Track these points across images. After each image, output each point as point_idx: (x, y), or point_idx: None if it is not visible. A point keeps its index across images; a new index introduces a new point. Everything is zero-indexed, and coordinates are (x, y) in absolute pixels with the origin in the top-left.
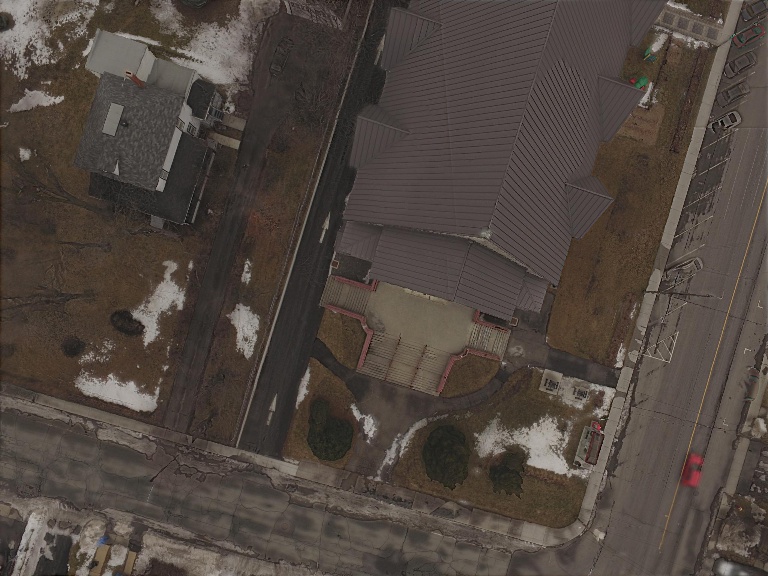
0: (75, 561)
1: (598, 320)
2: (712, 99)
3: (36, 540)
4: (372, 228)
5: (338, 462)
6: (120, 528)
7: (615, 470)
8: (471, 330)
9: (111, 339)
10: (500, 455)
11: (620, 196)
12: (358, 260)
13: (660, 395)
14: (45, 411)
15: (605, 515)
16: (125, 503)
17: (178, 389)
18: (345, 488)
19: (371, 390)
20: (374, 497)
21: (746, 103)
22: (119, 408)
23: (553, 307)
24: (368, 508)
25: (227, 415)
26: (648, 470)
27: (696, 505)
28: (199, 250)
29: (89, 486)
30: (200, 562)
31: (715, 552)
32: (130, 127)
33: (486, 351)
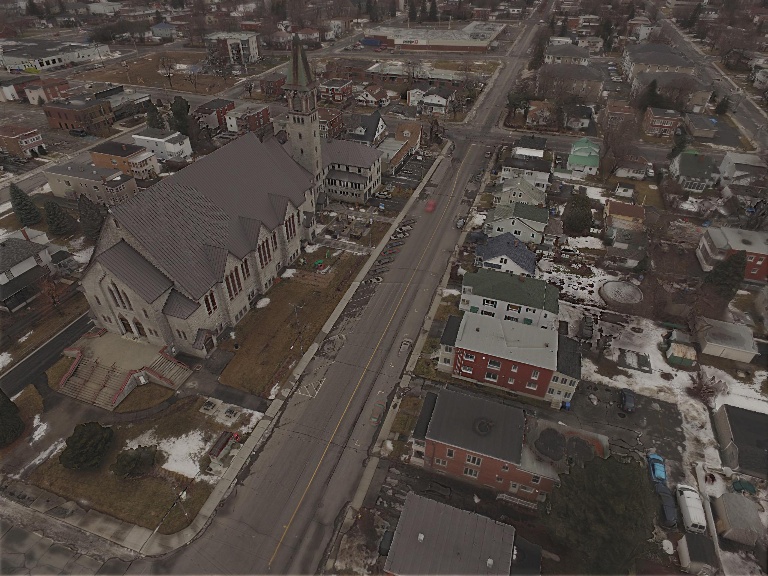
0: None
1: (263, 368)
2: (366, 272)
3: None
4: None
5: None
6: None
7: (245, 479)
8: (156, 359)
9: None
10: None
11: (298, 308)
12: None
13: (302, 420)
14: None
15: (221, 523)
16: None
17: None
18: None
19: (60, 405)
20: (1, 494)
21: (386, 274)
22: None
23: (232, 360)
24: None
25: None
26: (276, 480)
27: (319, 518)
28: (4, 325)
29: None
30: None
31: (333, 573)
32: (5, 247)
33: None
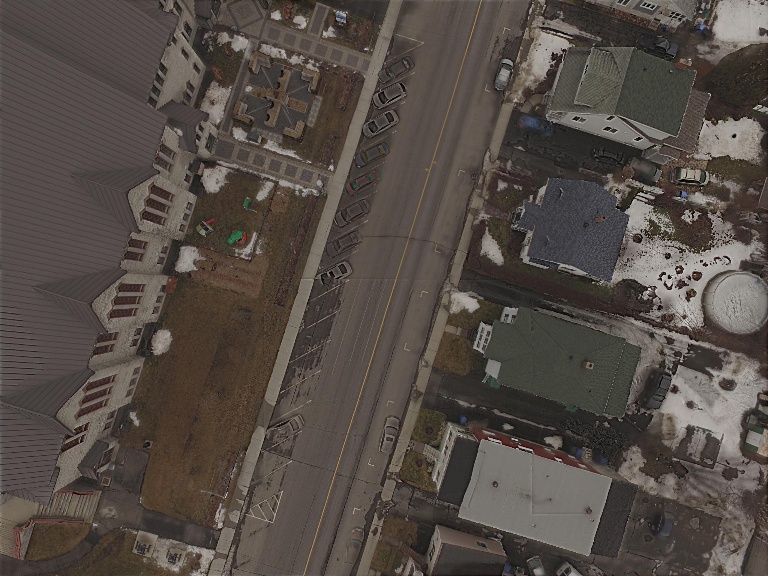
0: None
1: (195, 480)
2: (321, 249)
3: None
4: None
5: None
6: None
7: None
8: None
9: None
10: None
11: (220, 351)
12: None
13: (262, 557)
14: None
15: None
16: None
17: None
18: None
19: None
20: None
21: (358, 253)
22: None
23: (148, 466)
24: None
25: None
26: None
27: None
28: None
29: None
30: None
31: None
32: None
33: (66, 516)
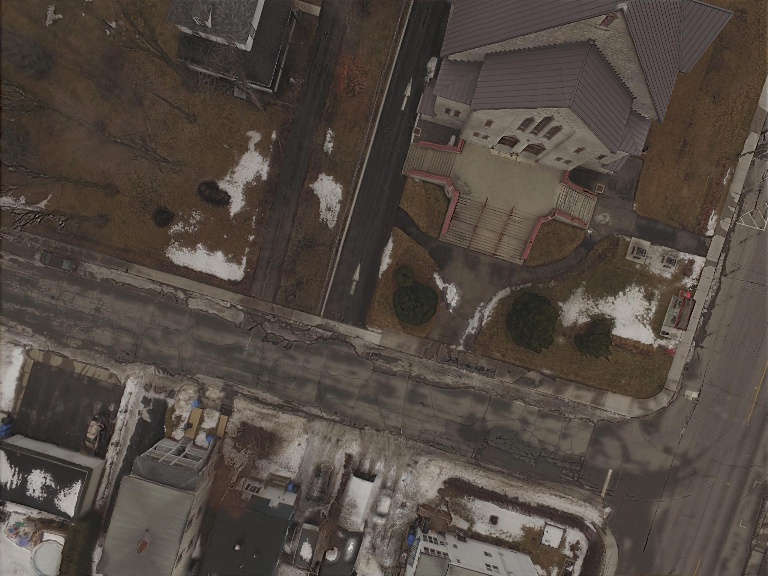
0: (171, 423)
1: (689, 186)
2: None
3: (134, 403)
4: (470, 65)
5: (421, 331)
6: (212, 393)
7: (703, 341)
8: (559, 192)
9: (199, 209)
10: (585, 324)
11: (715, 55)
12: (441, 127)
13: (753, 264)
14: (138, 281)
15: (692, 386)
16: (216, 369)
17: (264, 259)
18: (428, 357)
19: (454, 259)
20: (457, 366)
21: None
22: (208, 277)
23: (642, 173)
24: (451, 377)
25: (312, 284)
26: (738, 341)
27: None
28: (282, 120)
29: (182, 353)
30: (288, 426)
31: None
32: None
33: (572, 216)
